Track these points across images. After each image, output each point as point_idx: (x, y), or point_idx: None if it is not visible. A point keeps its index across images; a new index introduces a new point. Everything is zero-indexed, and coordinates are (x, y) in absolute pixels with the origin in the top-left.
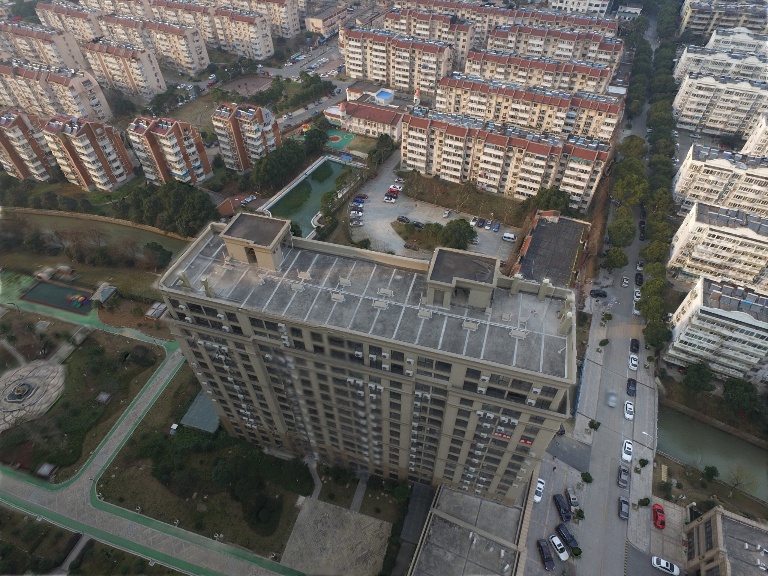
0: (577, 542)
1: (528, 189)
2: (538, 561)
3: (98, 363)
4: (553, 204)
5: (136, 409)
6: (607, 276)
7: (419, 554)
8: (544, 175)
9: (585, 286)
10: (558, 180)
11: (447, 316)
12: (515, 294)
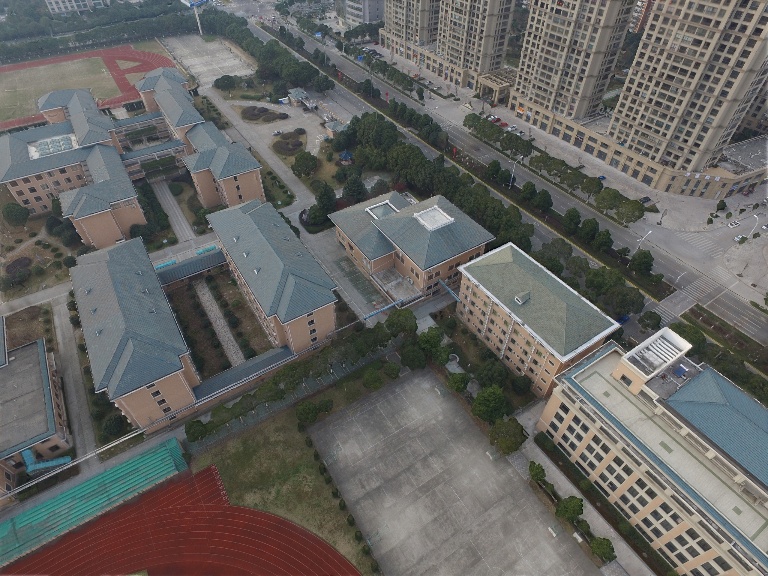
0: None
1: None
2: None
3: None
4: None
5: (616, 92)
6: None
7: (752, 140)
8: None
9: None
10: None
11: None
12: None
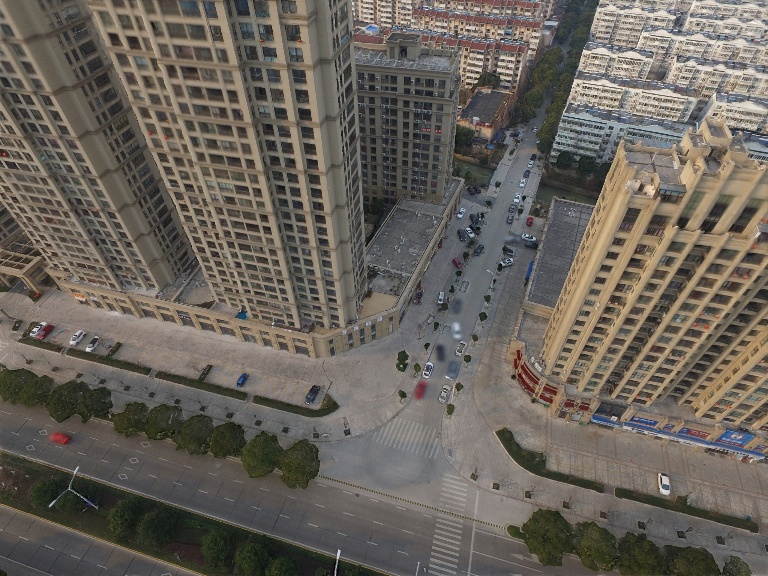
0: (480, 231)
1: (474, 79)
2: (457, 238)
3: None
4: (487, 81)
5: None
6: (523, 127)
7: (388, 220)
8: (484, 67)
9: (507, 131)
10: (495, 72)
11: (396, 62)
12: (431, 55)
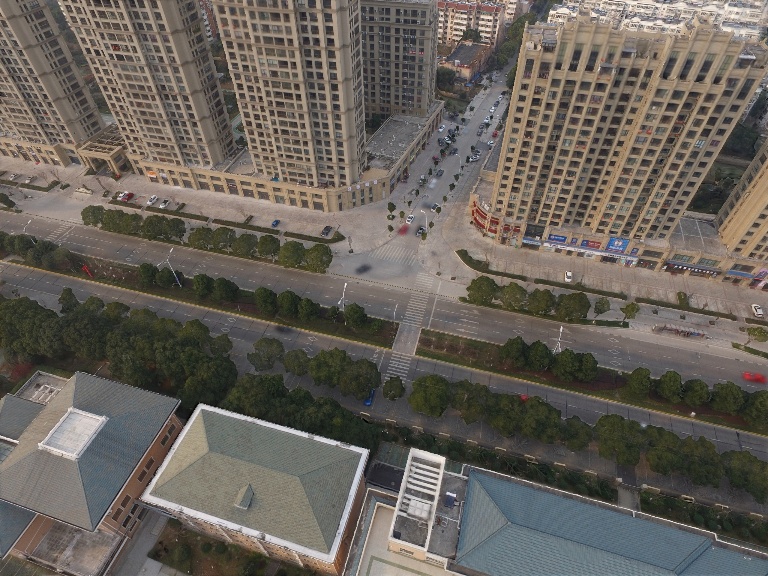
0: None
1: (459, 37)
2: (437, 144)
3: (224, 95)
4: (469, 35)
5: None
6: (498, 72)
7: (383, 126)
8: (467, 26)
9: (484, 76)
10: (477, 30)
11: None
12: None
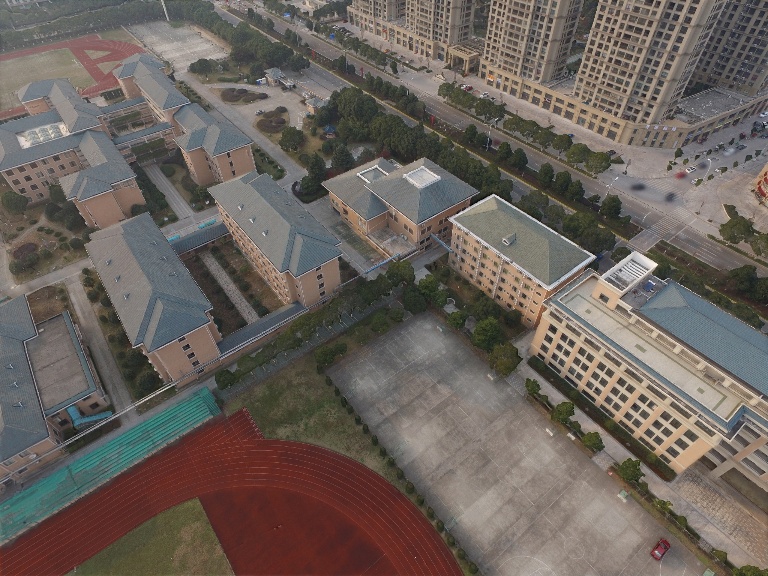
0: None
1: None
2: None
3: None
4: None
5: None
6: None
7: (703, 93)
8: None
9: None
10: None
11: None
12: None
